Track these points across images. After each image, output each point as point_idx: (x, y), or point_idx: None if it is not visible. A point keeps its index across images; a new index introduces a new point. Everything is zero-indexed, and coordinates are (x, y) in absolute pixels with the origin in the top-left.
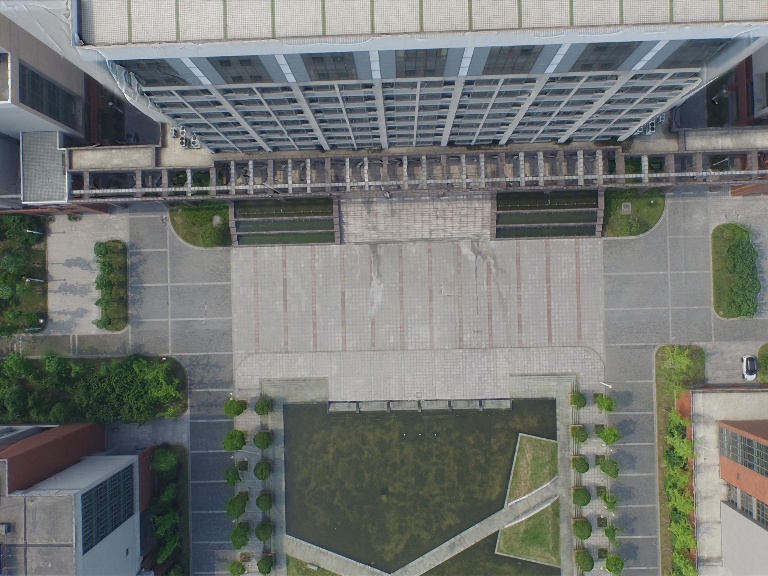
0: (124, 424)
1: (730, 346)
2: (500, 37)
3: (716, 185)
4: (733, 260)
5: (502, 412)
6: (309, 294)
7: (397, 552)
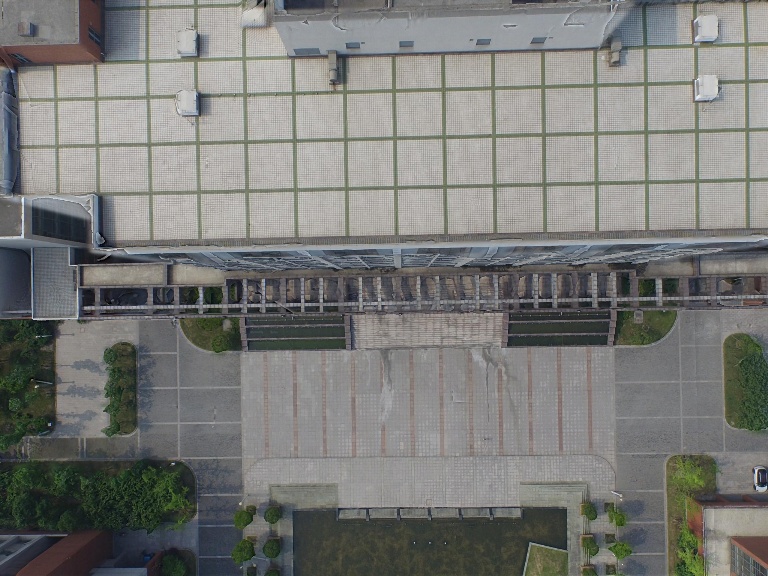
0: None
1: (741, 456)
2: (525, 240)
3: None
4: (745, 374)
5: (512, 521)
6: (319, 399)
7: None
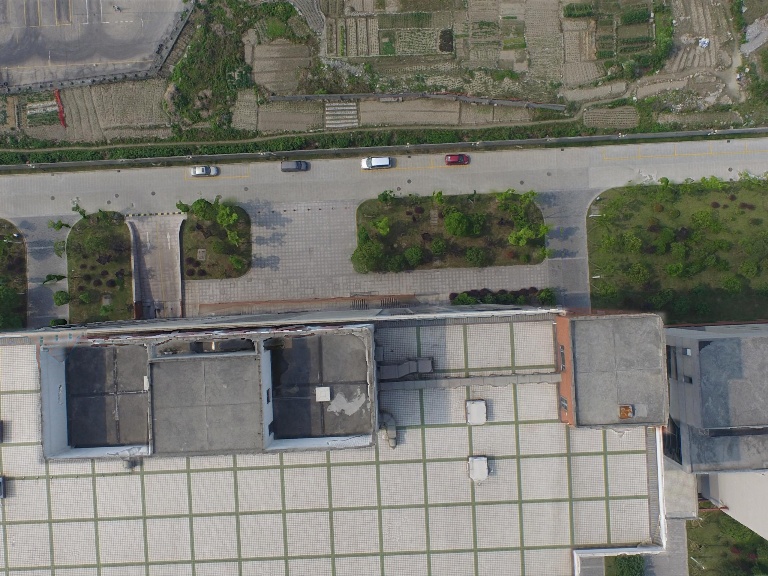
0: None
1: None
2: None
3: None
4: (620, 568)
5: None
6: None
7: None
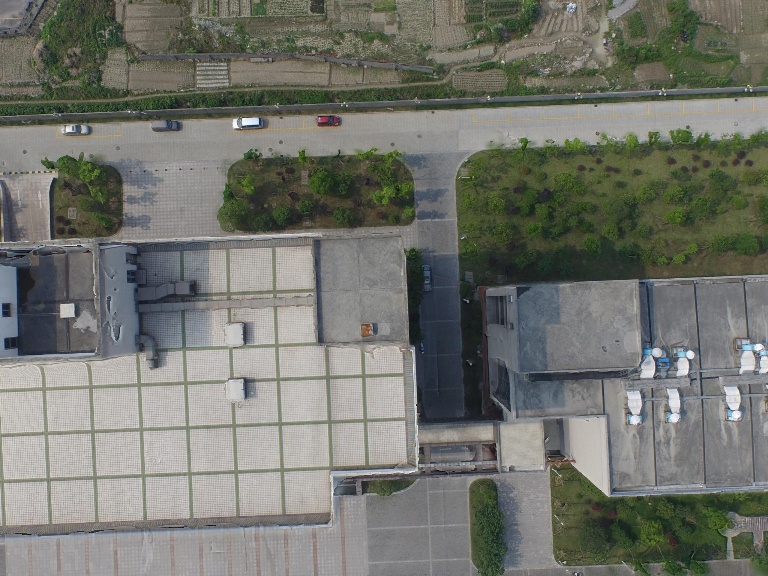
0: None
1: None
2: None
3: (469, 446)
4: (480, 524)
5: None
6: (82, 553)
7: None
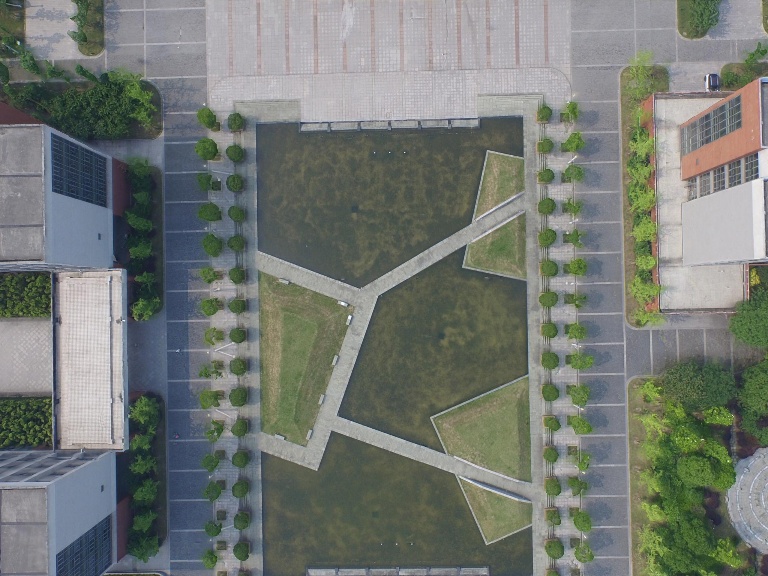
0: (100, 146)
1: (693, 66)
2: None
3: None
4: None
5: (470, 130)
6: (282, 18)
7: (367, 268)
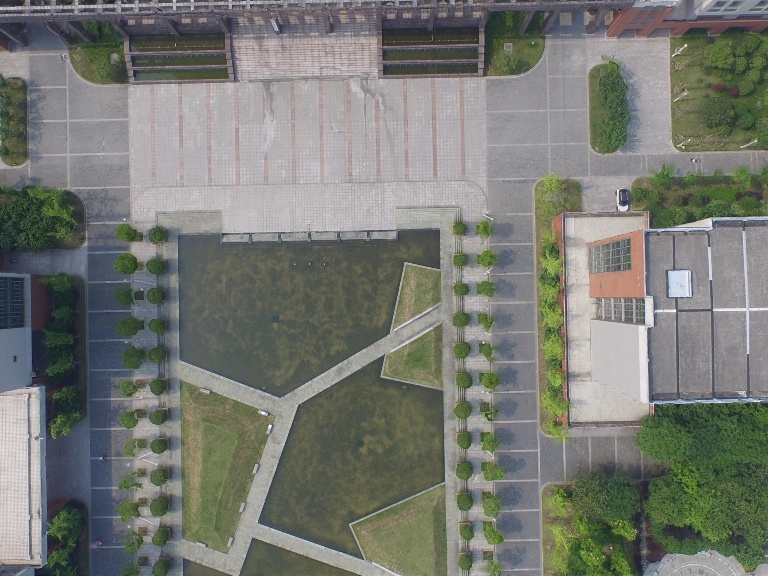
0: (23, 255)
1: (605, 180)
2: None
3: (591, 24)
4: (604, 92)
5: (389, 242)
6: (204, 130)
7: (287, 377)
